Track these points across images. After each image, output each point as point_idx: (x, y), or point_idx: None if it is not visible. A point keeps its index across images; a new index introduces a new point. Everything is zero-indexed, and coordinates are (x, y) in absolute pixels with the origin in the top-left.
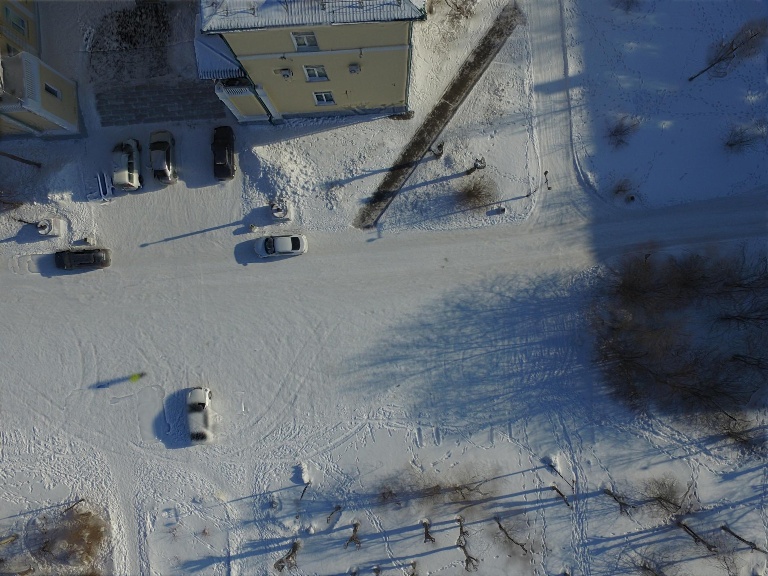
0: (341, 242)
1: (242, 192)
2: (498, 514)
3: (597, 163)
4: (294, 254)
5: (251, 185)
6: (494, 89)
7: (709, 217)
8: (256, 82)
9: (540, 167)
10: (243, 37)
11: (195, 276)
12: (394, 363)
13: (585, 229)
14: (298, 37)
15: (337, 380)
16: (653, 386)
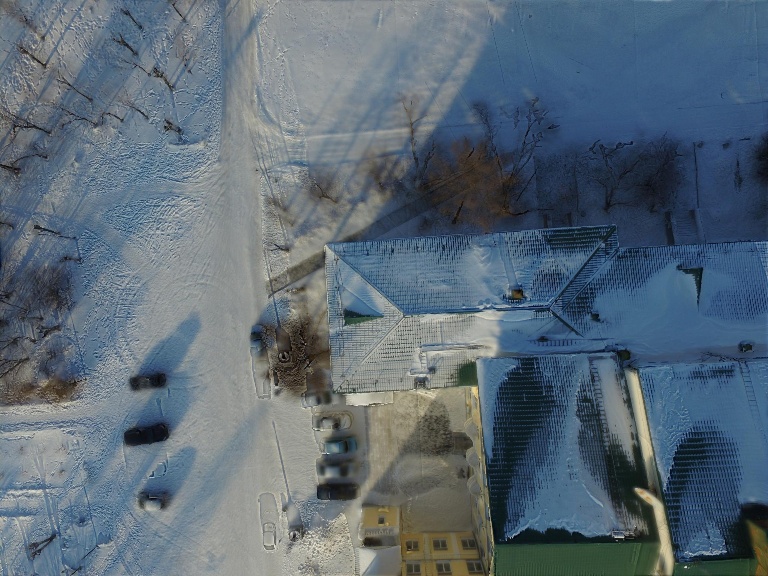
0: (275, 573)
1: (313, 501)
2: None
3: None
4: None
5: (317, 509)
6: None
7: None
8: None
9: None
10: None
11: (251, 462)
12: None
13: None
14: None
15: (173, 567)
16: None
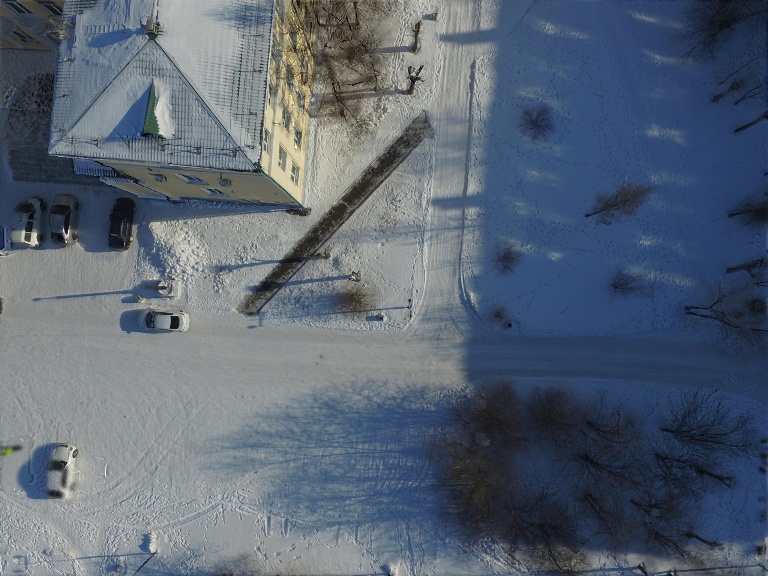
0: (223, 325)
1: (135, 262)
2: None
3: (481, 285)
4: (174, 331)
5: (144, 257)
6: (392, 198)
7: (585, 354)
8: (137, 177)
9: (425, 281)
10: None
11: (80, 336)
12: (255, 450)
13: (461, 347)
14: None
15: (198, 457)
16: (501, 513)
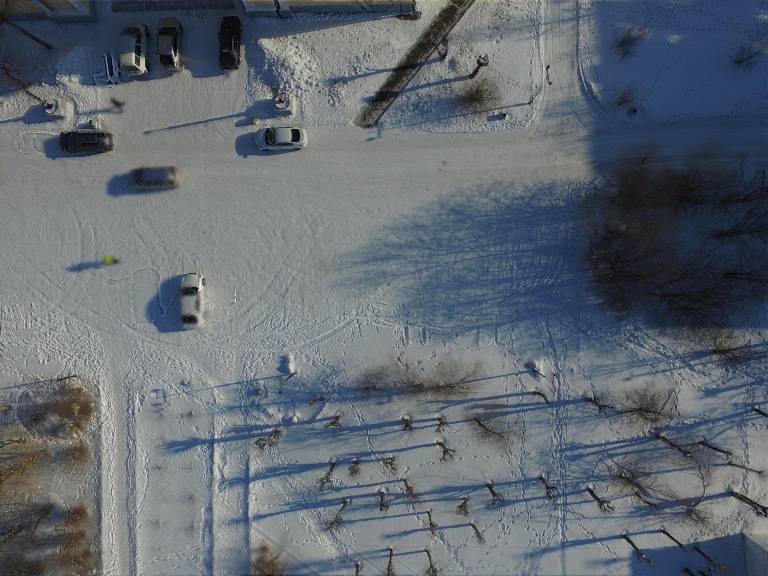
0: (341, 139)
1: (246, 84)
2: (479, 415)
3: (602, 74)
4: (294, 147)
5: (255, 77)
6: None
7: (711, 136)
8: None
9: (544, 75)
10: None
11: (195, 165)
12: (386, 262)
13: (585, 140)
14: None
15: (329, 275)
16: (642, 299)
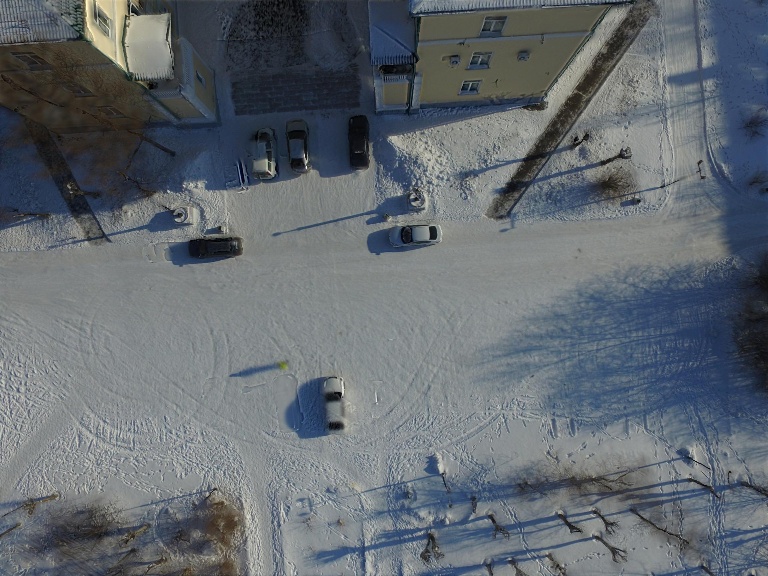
0: (474, 232)
1: (376, 181)
2: (634, 506)
3: (731, 155)
4: (430, 243)
5: (385, 174)
6: (628, 80)
7: None
8: (418, 69)
9: (674, 158)
10: (438, 21)
11: (327, 265)
12: (528, 353)
13: (719, 220)
14: (487, 22)
15: (471, 370)
16: None
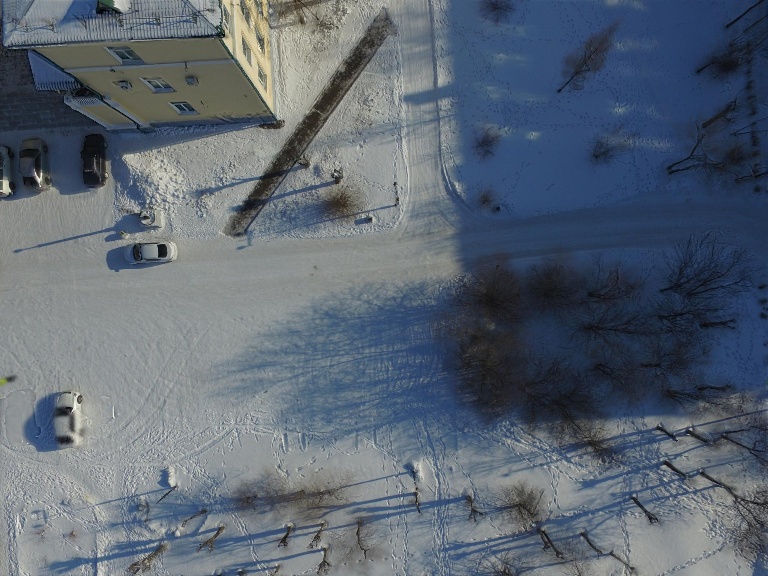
0: (212, 249)
1: (114, 199)
2: (361, 519)
3: (465, 173)
4: (163, 261)
5: (122, 192)
6: (364, 99)
7: (576, 227)
8: (102, 93)
9: (409, 177)
10: (57, 51)
11: (68, 282)
12: (262, 369)
13: (453, 238)
14: (117, 51)
15: (206, 385)
16: (515, 394)
